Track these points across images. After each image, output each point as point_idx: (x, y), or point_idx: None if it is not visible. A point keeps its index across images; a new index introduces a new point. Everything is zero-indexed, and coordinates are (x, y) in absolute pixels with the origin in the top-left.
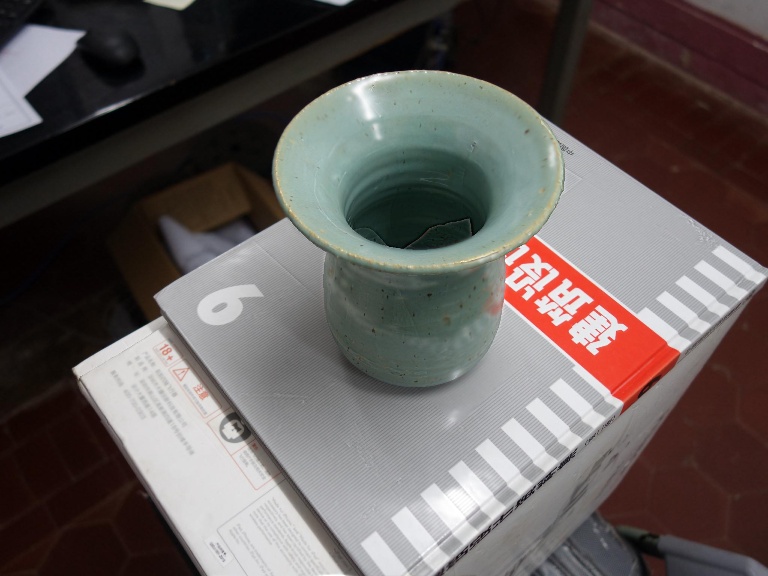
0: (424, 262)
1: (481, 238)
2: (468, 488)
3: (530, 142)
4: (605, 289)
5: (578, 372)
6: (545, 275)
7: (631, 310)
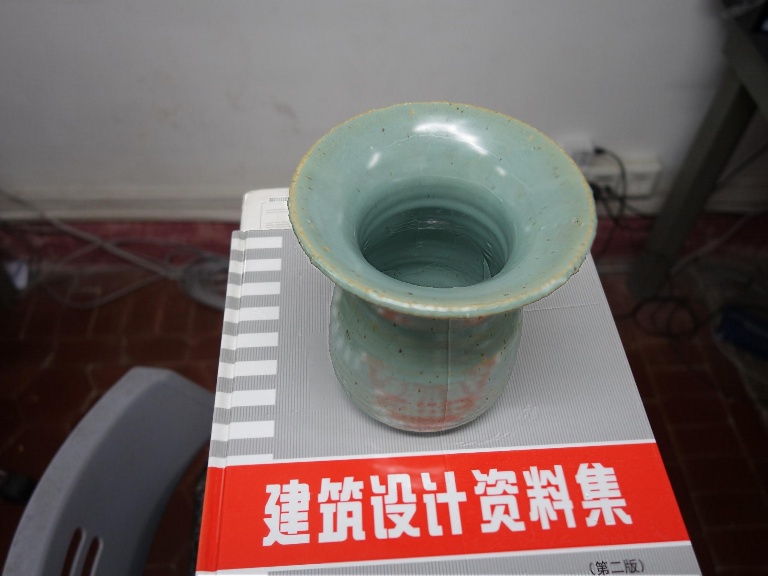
0: (329, 140)
1: (327, 196)
2: (258, 310)
3: (395, 288)
4: (321, 568)
5: (266, 456)
6: (385, 520)
7: (277, 570)
